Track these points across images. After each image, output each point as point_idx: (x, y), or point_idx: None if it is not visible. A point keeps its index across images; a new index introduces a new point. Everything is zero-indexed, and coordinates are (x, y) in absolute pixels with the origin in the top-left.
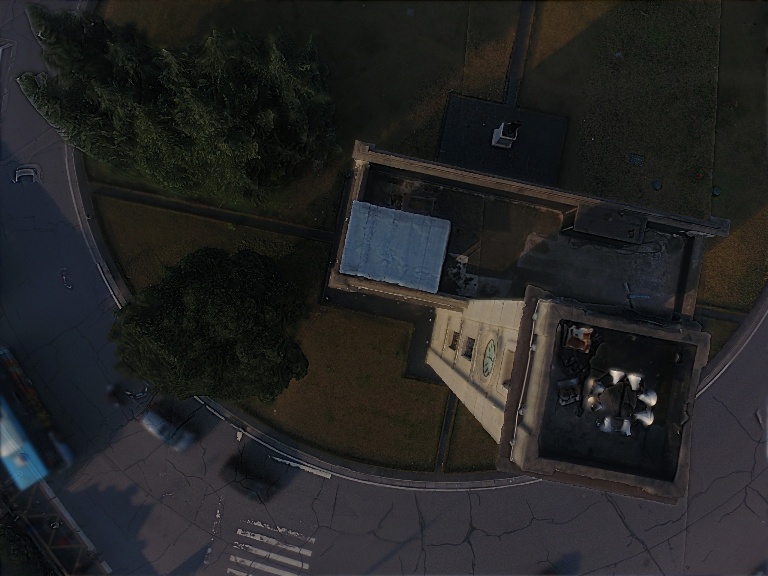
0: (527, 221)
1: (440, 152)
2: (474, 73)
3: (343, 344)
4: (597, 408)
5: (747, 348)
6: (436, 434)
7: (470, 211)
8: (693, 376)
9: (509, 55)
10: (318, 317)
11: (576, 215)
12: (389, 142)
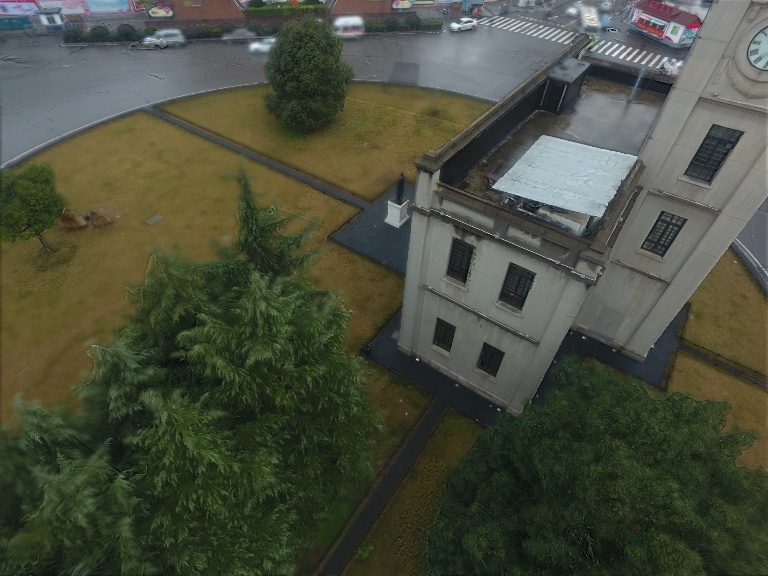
0: (541, 127)
1: (384, 264)
2: (321, 217)
3: None
4: None
5: None
6: (749, 386)
7: (519, 152)
8: None
9: (321, 194)
10: None
11: (557, 78)
12: (348, 300)
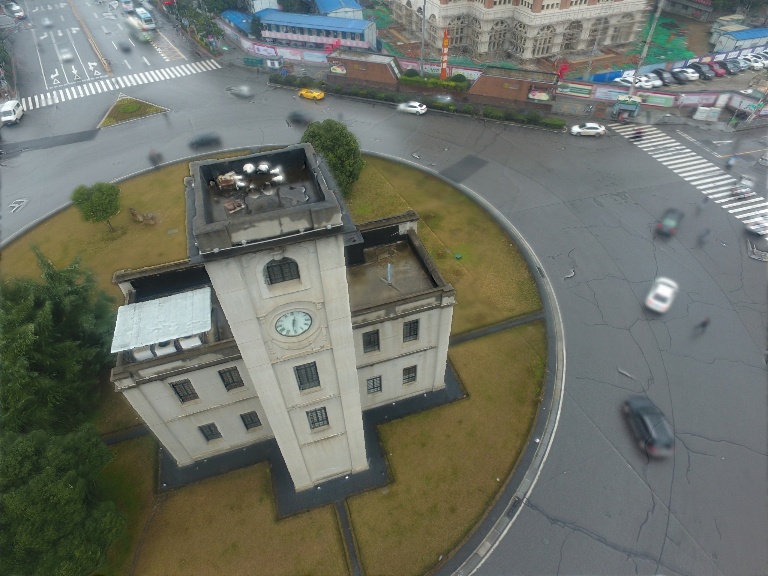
0: None
1: None
2: None
3: (194, 522)
4: (238, 182)
5: (566, 331)
6: (343, 568)
7: None
8: (308, 158)
9: None
10: (157, 509)
11: None
12: None
